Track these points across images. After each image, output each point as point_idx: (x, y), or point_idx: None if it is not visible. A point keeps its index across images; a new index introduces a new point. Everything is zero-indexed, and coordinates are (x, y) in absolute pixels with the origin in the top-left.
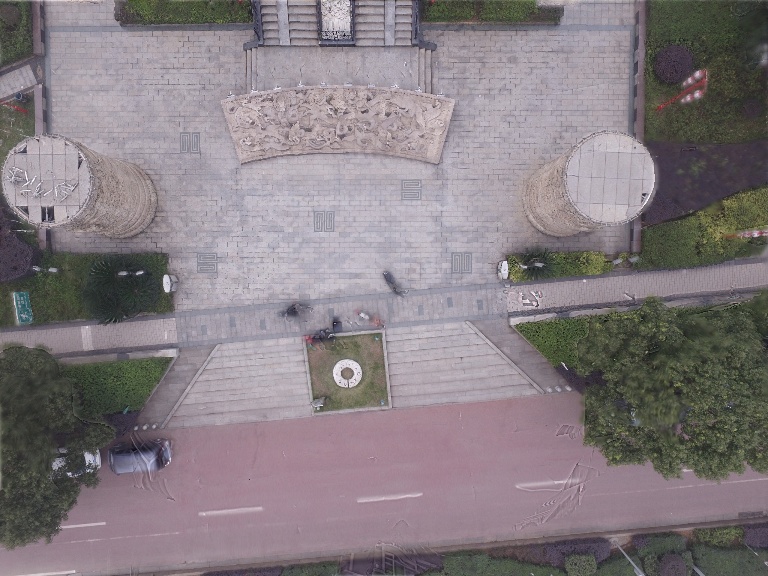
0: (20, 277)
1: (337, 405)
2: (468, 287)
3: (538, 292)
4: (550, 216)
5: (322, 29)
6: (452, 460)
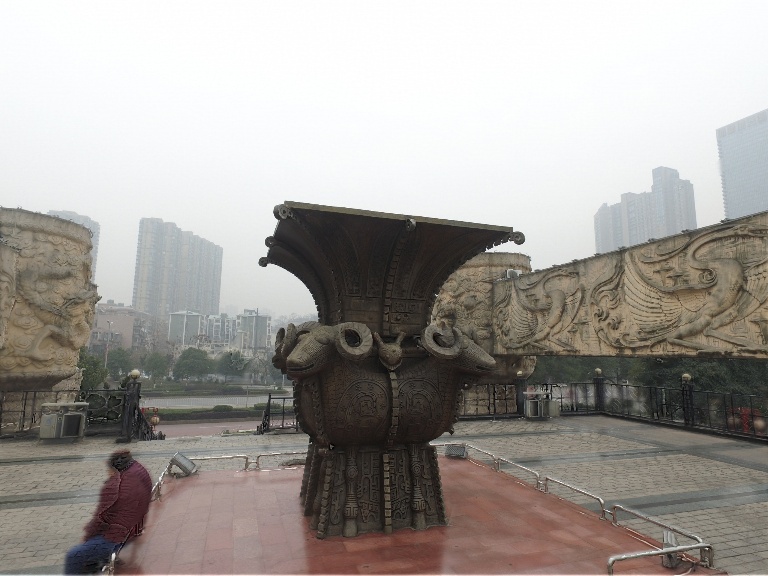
0: None
1: None
2: None
3: None
4: None
5: None
6: (178, 431)
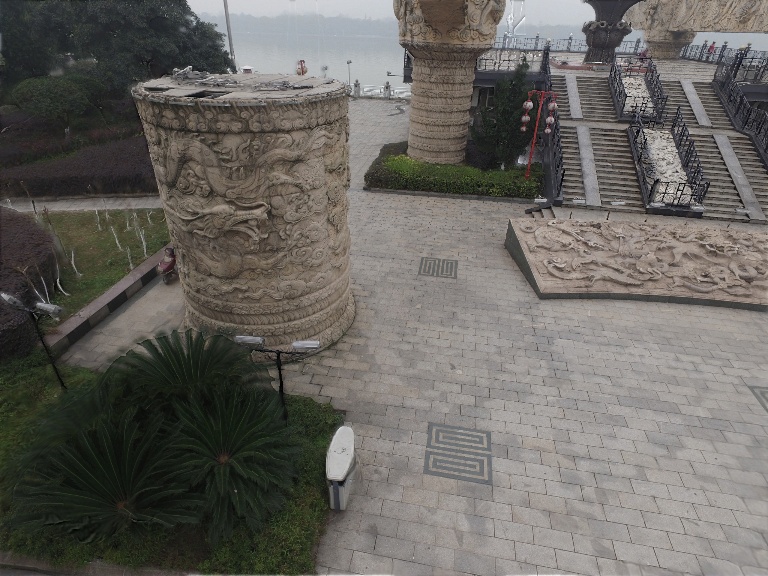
0: None
1: None
2: None
3: None
4: None
5: None
6: None
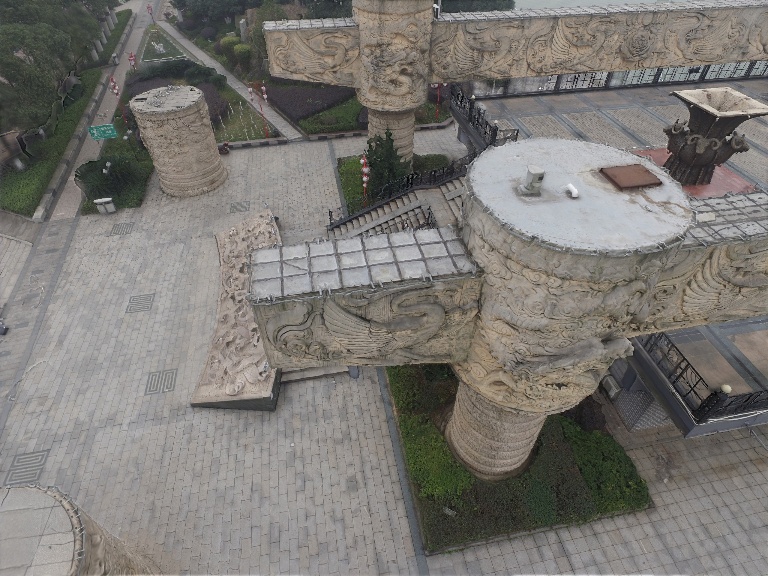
0: None
1: None
2: None
3: None
4: None
5: None
6: None
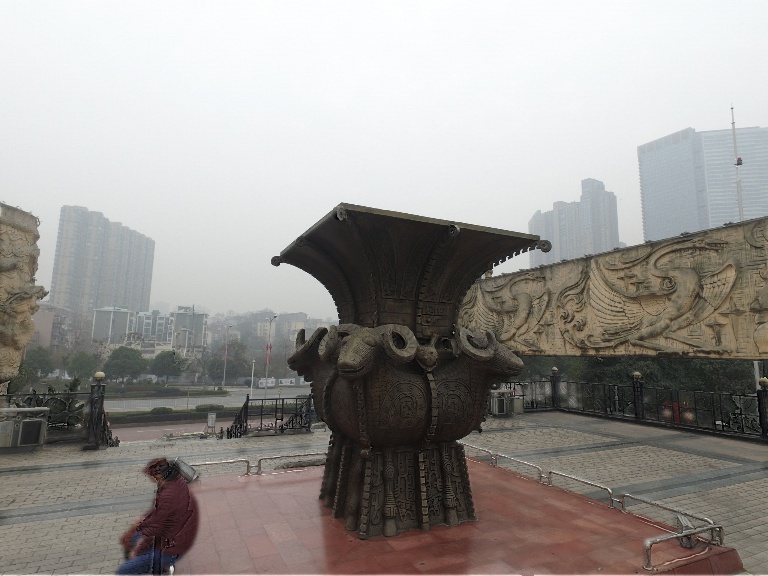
0: None
1: None
2: None
3: None
4: None
5: None
6: None
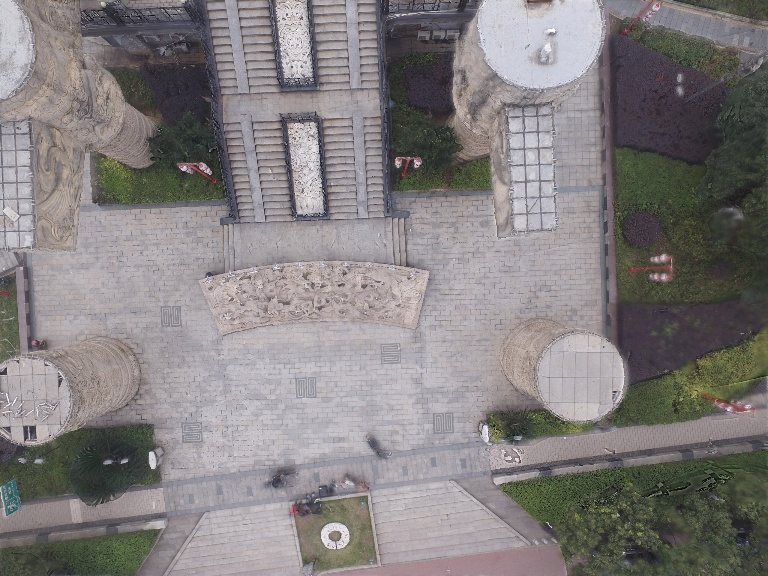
0: (7, 460)
1: (326, 565)
2: (451, 446)
3: (520, 449)
4: (526, 394)
5: (296, 208)
6: None
